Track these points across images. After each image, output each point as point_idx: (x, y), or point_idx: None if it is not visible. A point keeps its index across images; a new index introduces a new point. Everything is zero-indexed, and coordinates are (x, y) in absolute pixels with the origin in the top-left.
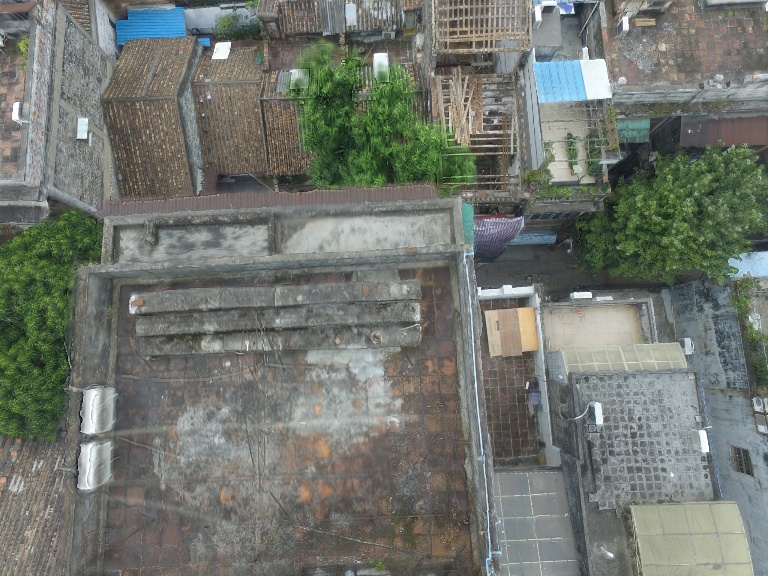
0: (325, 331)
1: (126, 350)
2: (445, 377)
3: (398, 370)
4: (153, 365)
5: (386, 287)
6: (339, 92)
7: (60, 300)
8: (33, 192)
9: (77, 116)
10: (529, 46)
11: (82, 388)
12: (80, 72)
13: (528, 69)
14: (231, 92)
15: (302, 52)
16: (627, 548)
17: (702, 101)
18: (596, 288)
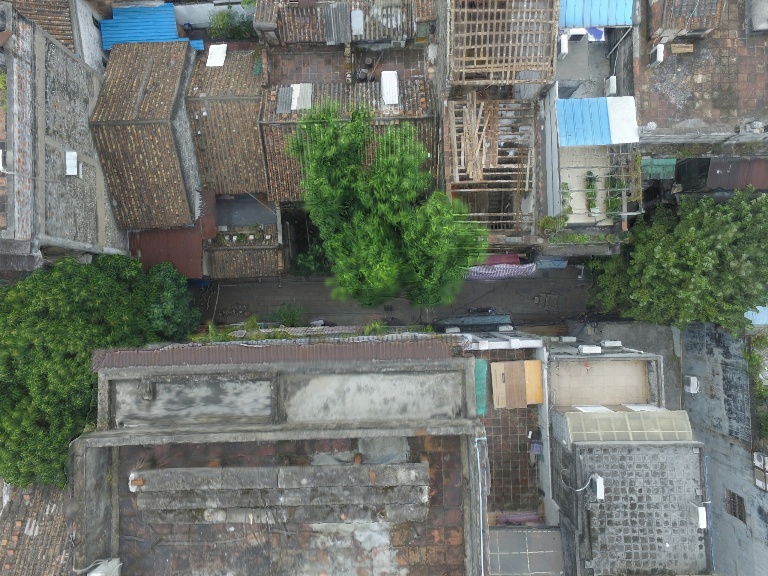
0: (330, 505)
1: (128, 511)
2: (451, 547)
3: (404, 539)
4: (156, 528)
5: (393, 472)
6: (344, 150)
7: (60, 367)
8: (24, 245)
9: (65, 149)
10: (552, 78)
11: (86, 567)
12: (65, 98)
13: (549, 102)
14: (228, 108)
15: (304, 61)
16: None
17: (735, 142)
18: (605, 319)
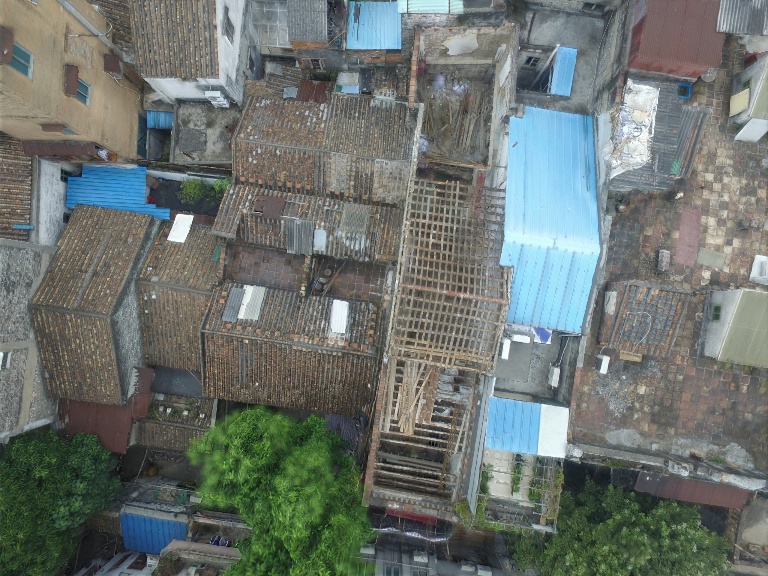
0: None
1: None
2: None
3: None
4: None
5: None
6: None
7: None
8: None
9: None
10: (491, 372)
11: None
12: (1, 294)
13: (487, 387)
14: (178, 297)
15: (264, 257)
16: None
17: None
18: None
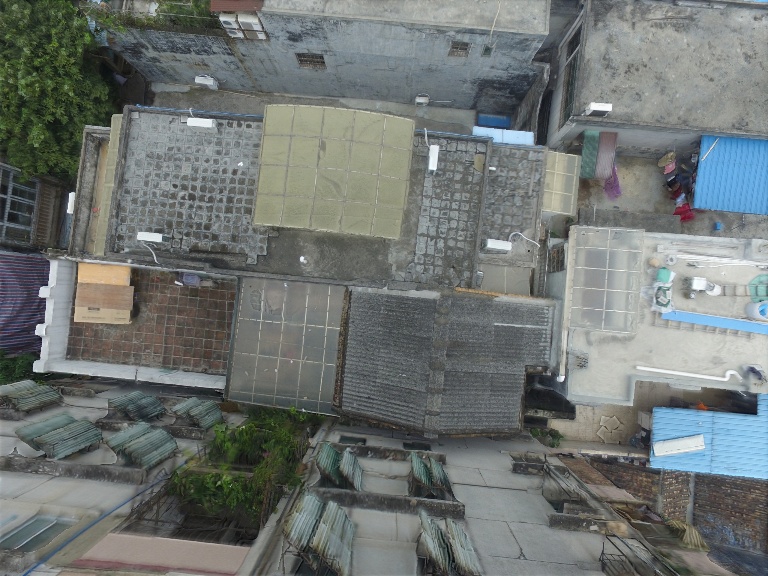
0: None
1: None
2: None
3: None
4: None
5: None
6: None
7: None
8: None
9: None
10: None
11: None
12: None
13: None
14: None
15: None
16: (312, 232)
17: None
18: None
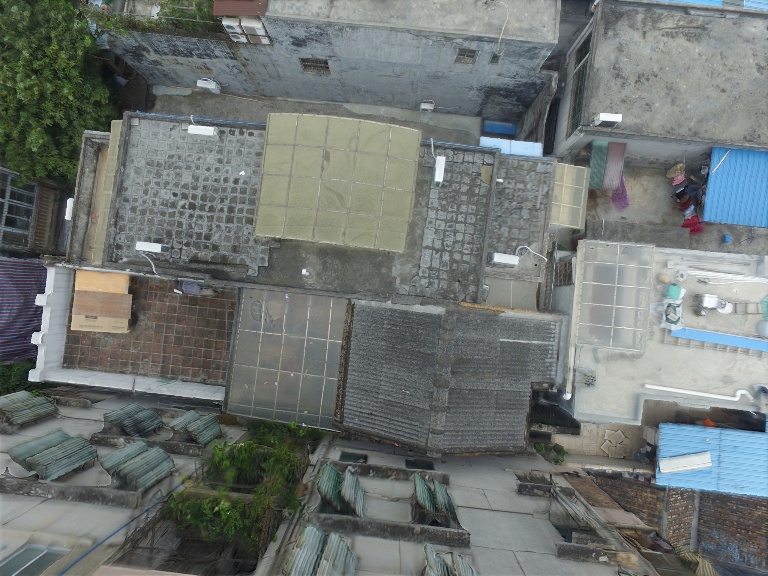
0: None
1: None
2: None
3: None
4: None
5: None
6: None
7: None
8: None
9: None
10: None
11: None
12: None
13: None
14: None
15: None
16: (314, 244)
17: None
18: None
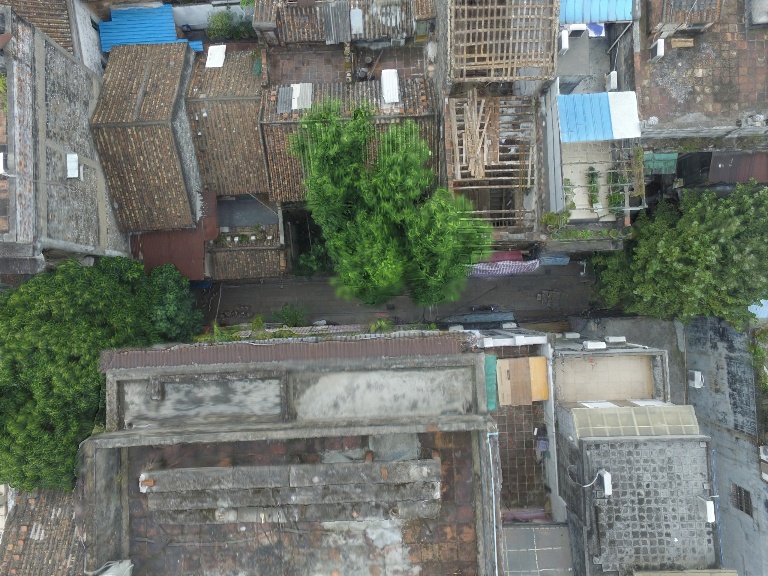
0: (342, 503)
1: (138, 513)
2: (464, 544)
3: (416, 536)
4: (167, 529)
5: (405, 469)
6: (347, 148)
7: (65, 370)
8: (27, 248)
9: (66, 152)
10: (553, 74)
11: (97, 569)
12: (65, 101)
13: (550, 98)
14: (228, 109)
15: (303, 61)
16: None
17: (737, 136)
18: (608, 315)
